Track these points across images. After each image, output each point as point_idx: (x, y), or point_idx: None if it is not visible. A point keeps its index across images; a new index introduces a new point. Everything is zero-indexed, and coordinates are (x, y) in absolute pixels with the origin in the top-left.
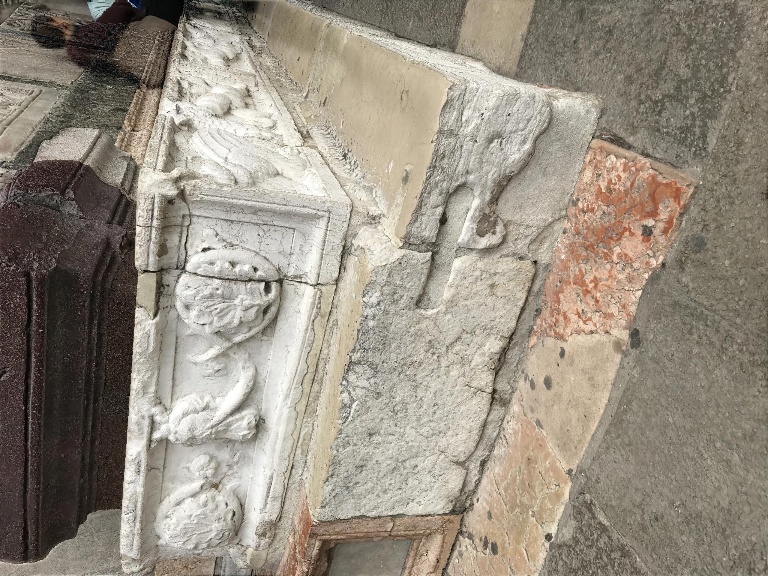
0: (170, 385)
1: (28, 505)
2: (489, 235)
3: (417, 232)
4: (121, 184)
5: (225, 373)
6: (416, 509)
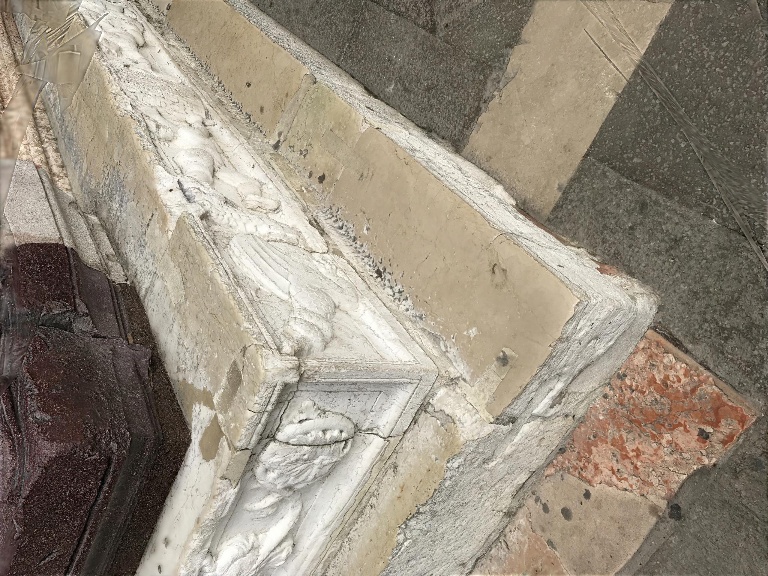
0: (221, 534)
1: None
2: (556, 406)
3: (510, 412)
4: (100, 262)
5: (274, 514)
6: None
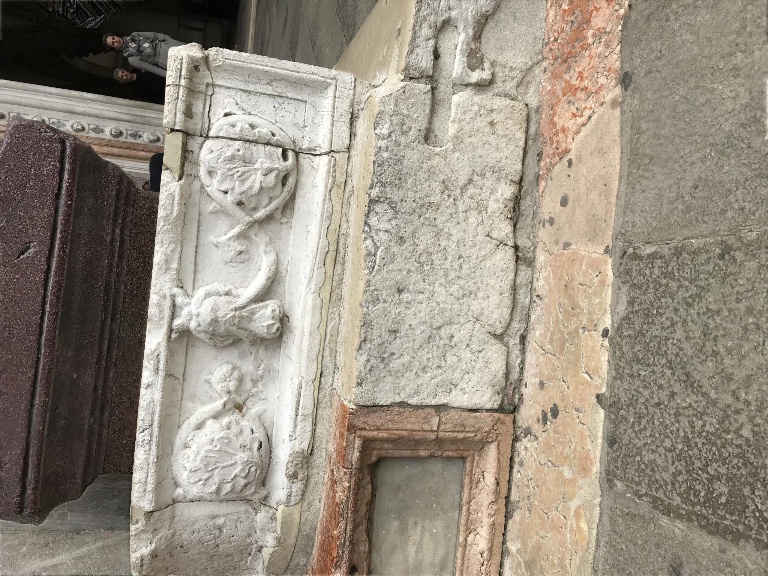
0: (192, 268)
1: (33, 425)
2: (479, 71)
3: (415, 63)
4: None
5: (247, 258)
6: (461, 399)
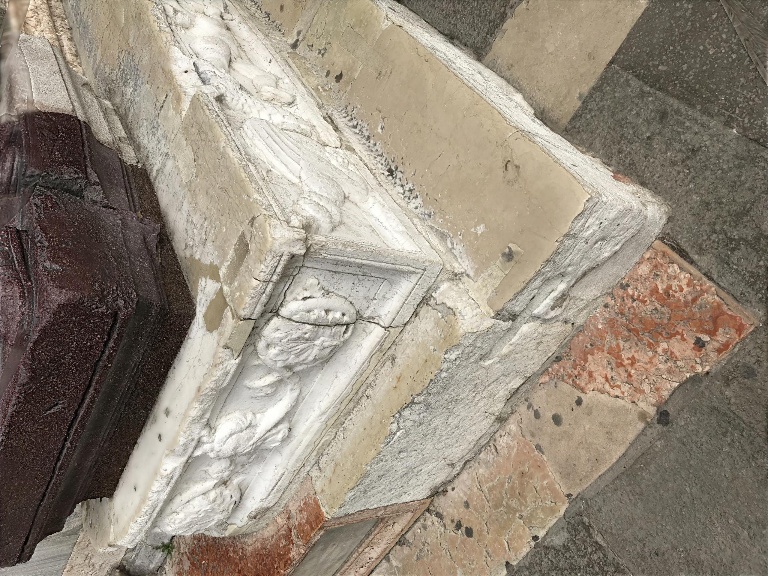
0: (220, 407)
1: (37, 516)
2: (557, 308)
3: (511, 307)
4: (112, 141)
5: (273, 394)
6: (405, 499)
